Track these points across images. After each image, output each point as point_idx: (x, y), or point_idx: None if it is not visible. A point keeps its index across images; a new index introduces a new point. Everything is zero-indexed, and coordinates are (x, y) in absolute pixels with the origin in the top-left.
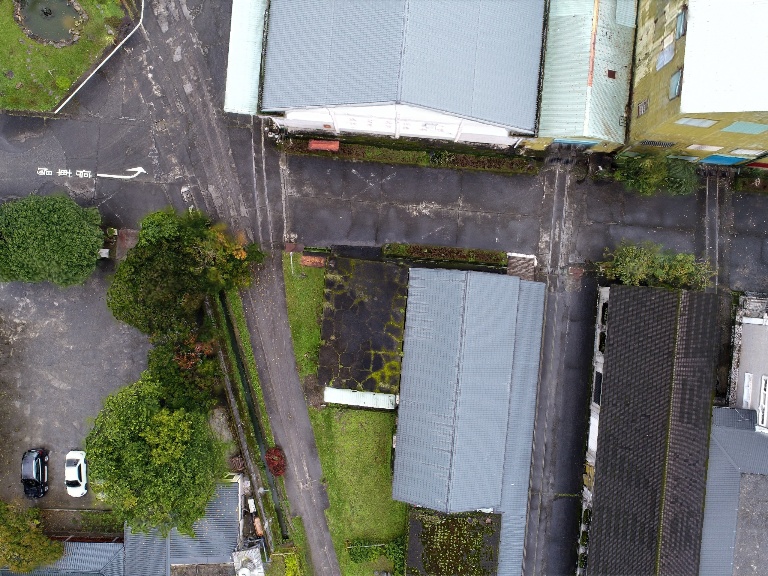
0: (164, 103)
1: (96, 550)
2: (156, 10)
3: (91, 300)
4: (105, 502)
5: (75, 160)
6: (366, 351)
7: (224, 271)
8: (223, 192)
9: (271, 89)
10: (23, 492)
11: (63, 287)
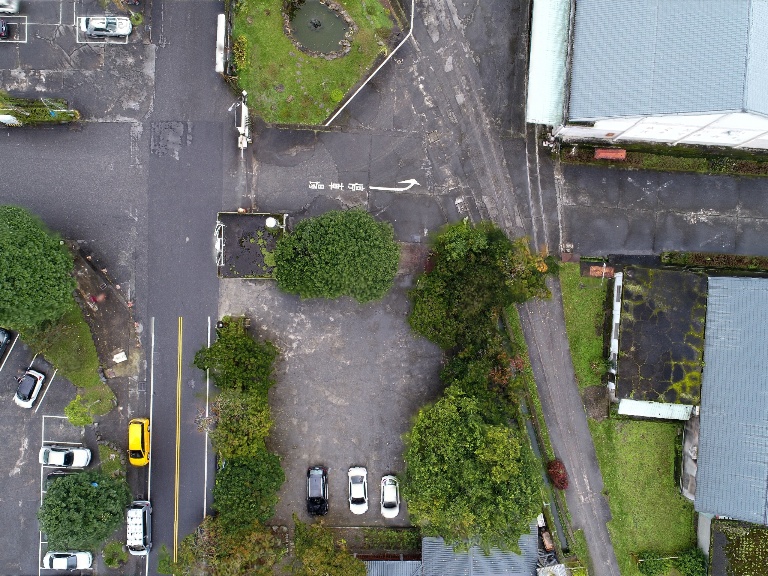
0: (436, 114)
1: (394, 568)
2: (426, 20)
3: (367, 314)
4: (386, 519)
5: (347, 173)
6: (666, 362)
7: (528, 284)
8: (498, 203)
9: (580, 99)
10: (302, 510)
11: (339, 302)
